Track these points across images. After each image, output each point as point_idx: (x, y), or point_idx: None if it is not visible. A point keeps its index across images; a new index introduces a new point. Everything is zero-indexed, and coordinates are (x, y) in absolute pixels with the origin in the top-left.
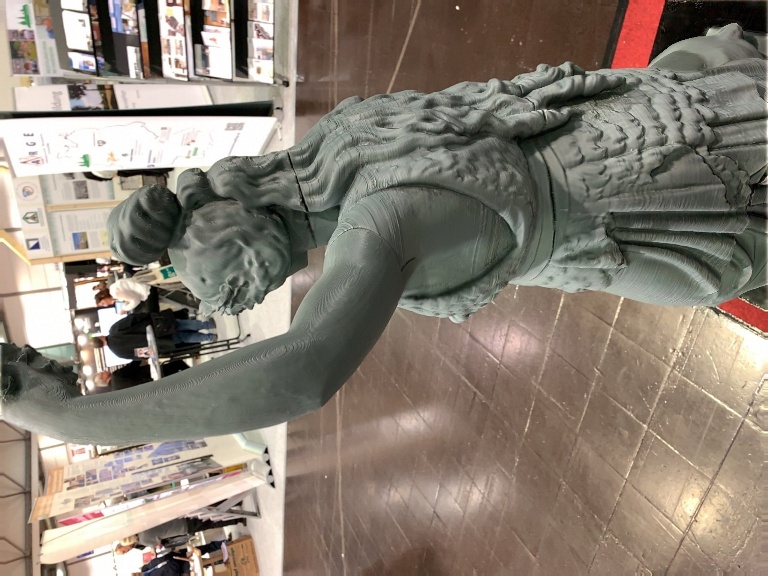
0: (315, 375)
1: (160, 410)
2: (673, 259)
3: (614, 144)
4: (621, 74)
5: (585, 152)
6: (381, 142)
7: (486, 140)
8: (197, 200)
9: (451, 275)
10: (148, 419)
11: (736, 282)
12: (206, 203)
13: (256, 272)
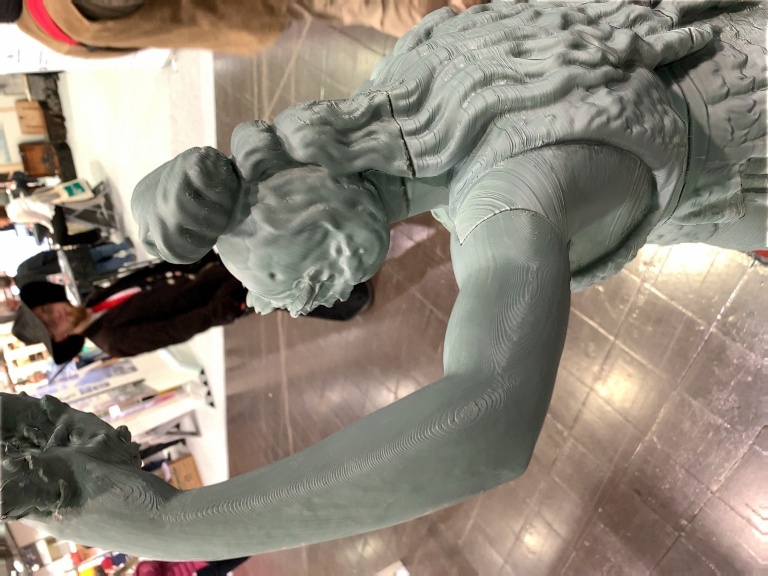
0: (520, 439)
1: (310, 514)
2: None
3: (762, 72)
4: None
5: (730, 83)
6: (523, 80)
7: (640, 72)
8: (265, 168)
9: (586, 250)
10: (293, 528)
11: None
12: (277, 171)
13: (347, 263)
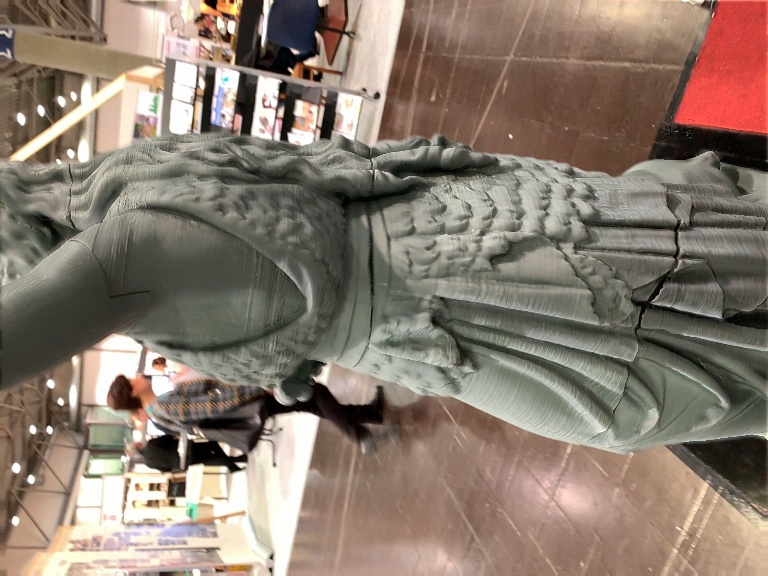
0: None
1: None
2: (539, 375)
3: (454, 220)
4: (501, 157)
5: (417, 223)
6: (154, 164)
7: (284, 185)
8: None
9: (218, 328)
10: None
11: (639, 426)
12: None
13: None
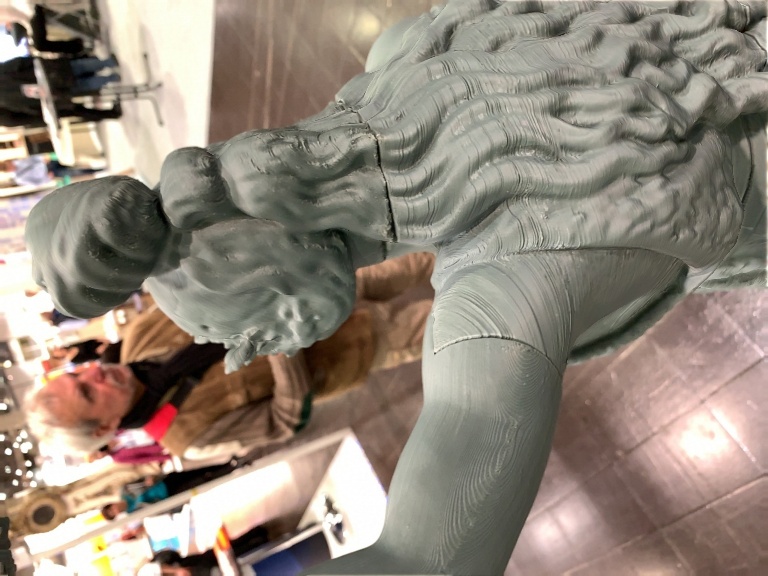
0: None
1: None
2: None
3: None
4: None
5: None
6: (557, 154)
7: (708, 144)
8: (202, 217)
9: (585, 334)
10: None
11: None
12: (218, 222)
13: (297, 328)
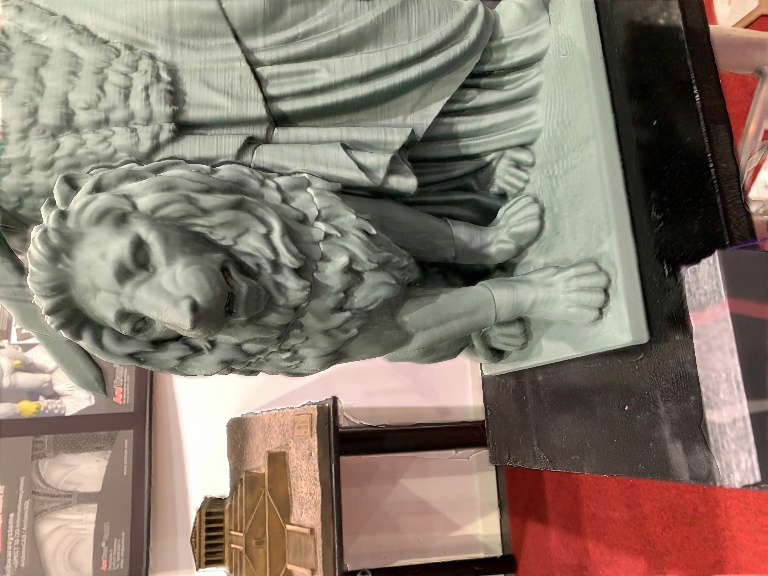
0: None
1: None
2: None
3: None
4: None
5: None
6: None
7: None
8: None
9: None
10: None
11: None
12: None
13: None
